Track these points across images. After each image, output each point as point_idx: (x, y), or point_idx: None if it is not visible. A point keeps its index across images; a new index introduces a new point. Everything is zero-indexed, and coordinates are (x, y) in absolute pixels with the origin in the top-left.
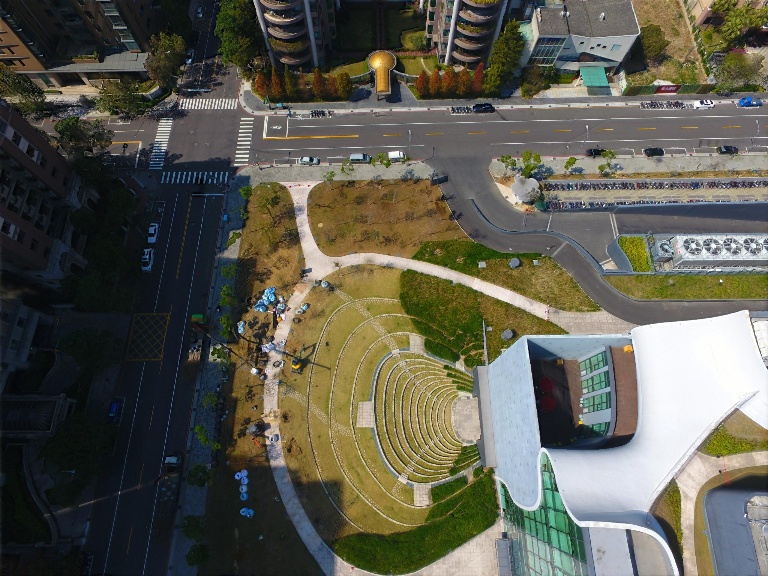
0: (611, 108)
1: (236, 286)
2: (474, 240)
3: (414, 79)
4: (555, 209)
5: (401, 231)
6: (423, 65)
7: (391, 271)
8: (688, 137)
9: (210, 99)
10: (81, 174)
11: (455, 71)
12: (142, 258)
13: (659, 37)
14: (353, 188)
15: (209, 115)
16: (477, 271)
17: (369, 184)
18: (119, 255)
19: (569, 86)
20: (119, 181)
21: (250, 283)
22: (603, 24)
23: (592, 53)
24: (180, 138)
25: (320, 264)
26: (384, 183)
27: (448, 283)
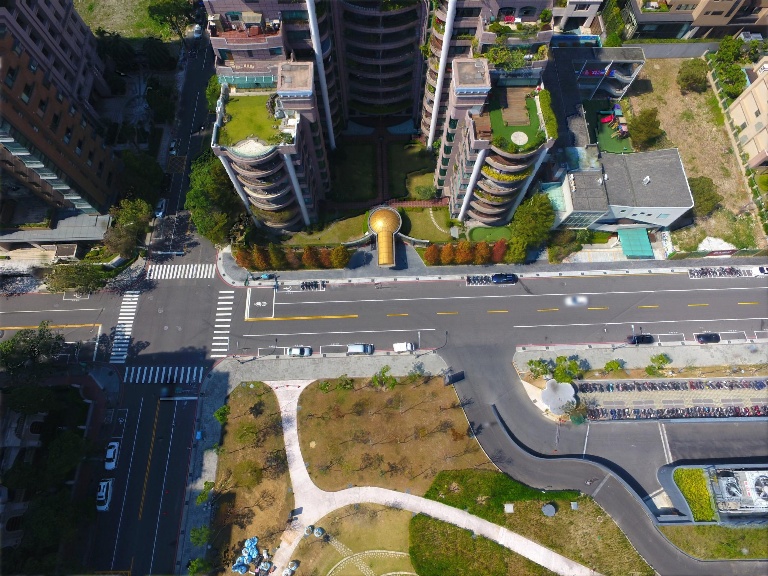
0: (654, 276)
1: (211, 531)
2: (498, 467)
3: (422, 242)
4: (594, 421)
5: (410, 455)
6: (432, 219)
7: (398, 514)
8: (747, 316)
9: (183, 265)
10: (18, 411)
11: (470, 229)
12: (97, 496)
13: (712, 195)
14: (352, 390)
15: (182, 287)
16: (503, 518)
17: (371, 384)
18: (63, 524)
19: (604, 247)
20: (72, 388)
21: (228, 528)
22: (648, 189)
23: (634, 219)
24: (147, 319)
25: (312, 502)
26: (388, 383)
27: (468, 536)
